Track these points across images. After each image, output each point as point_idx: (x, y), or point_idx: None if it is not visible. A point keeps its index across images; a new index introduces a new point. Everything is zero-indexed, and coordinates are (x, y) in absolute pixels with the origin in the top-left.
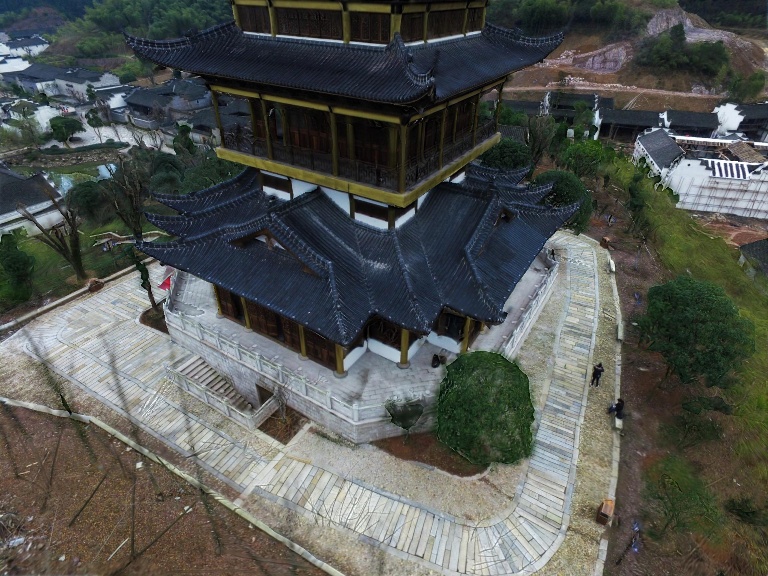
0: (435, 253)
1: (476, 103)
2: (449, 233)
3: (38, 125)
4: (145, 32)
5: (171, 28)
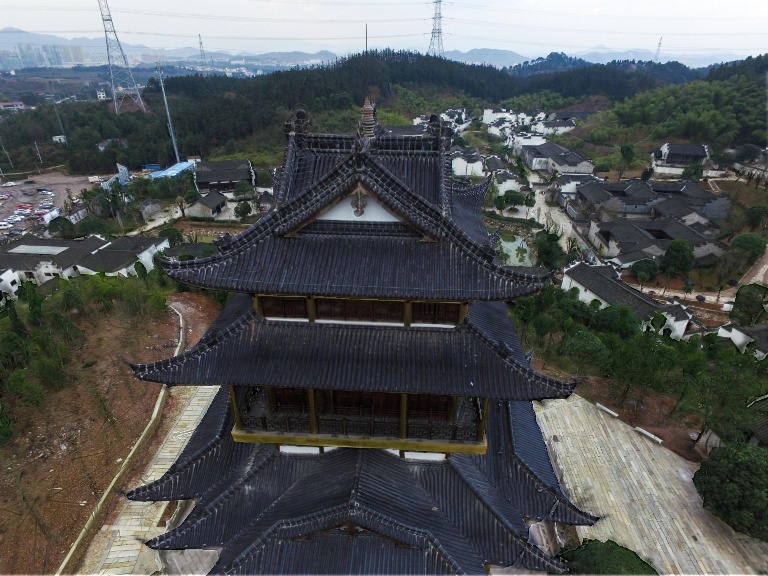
0: (286, 500)
1: (400, 397)
2: (310, 496)
3: (497, 192)
4: (652, 129)
5: (679, 129)
